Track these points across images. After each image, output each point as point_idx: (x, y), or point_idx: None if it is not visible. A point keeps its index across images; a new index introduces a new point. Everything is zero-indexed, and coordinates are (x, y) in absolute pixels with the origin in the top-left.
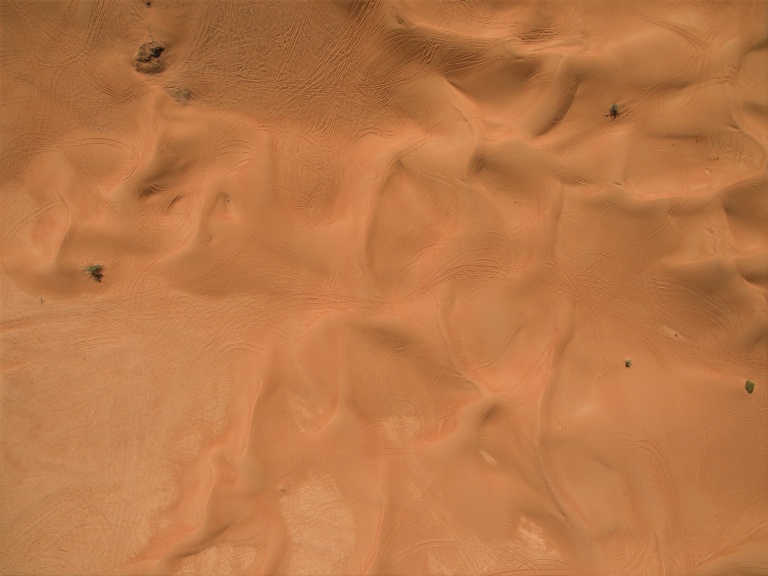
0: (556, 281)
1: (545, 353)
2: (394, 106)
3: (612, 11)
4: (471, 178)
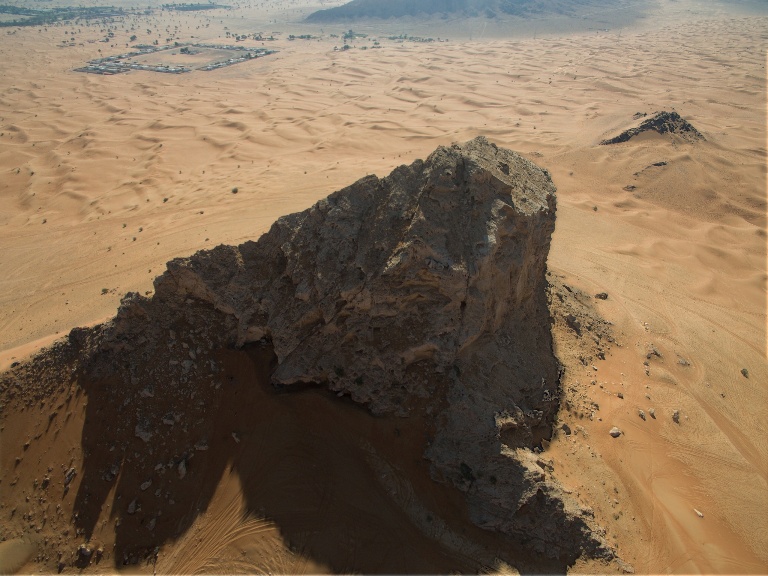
0: None
1: None
2: (720, 220)
3: None
4: (757, 235)
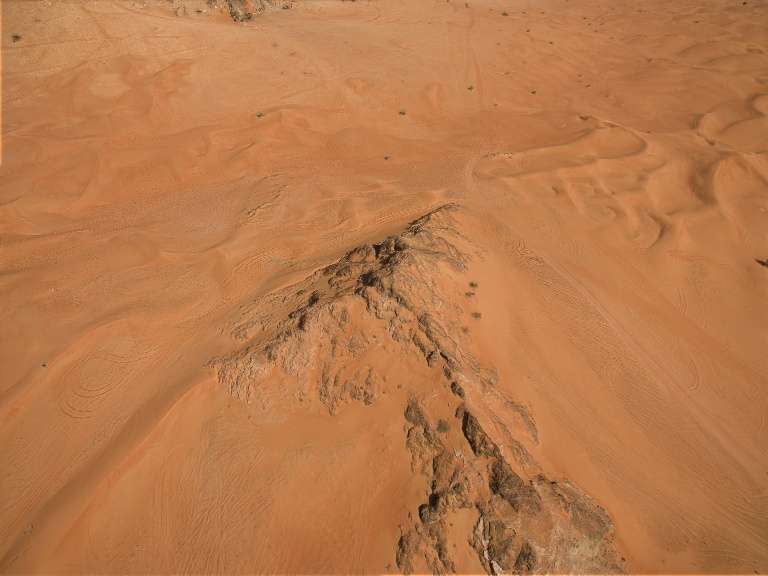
0: None
1: None
2: None
3: None
4: None
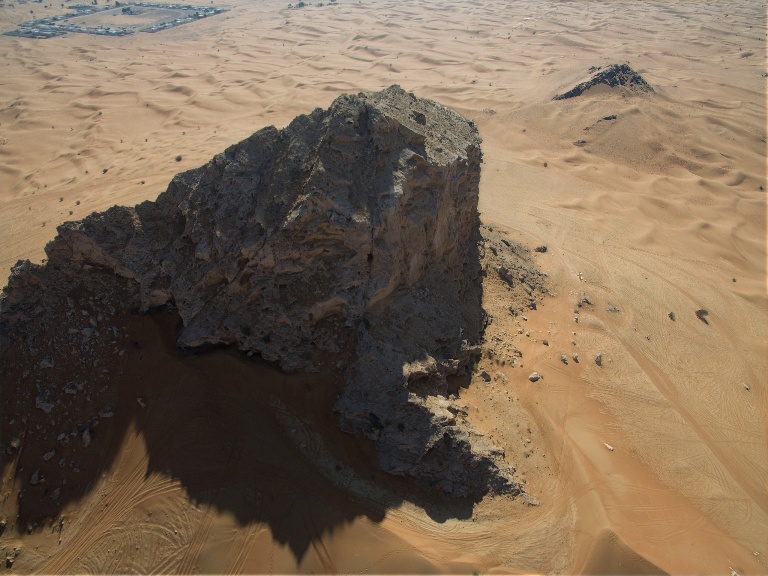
0: (737, 212)
1: (732, 223)
2: (666, 172)
3: (759, 173)
4: (698, 185)
